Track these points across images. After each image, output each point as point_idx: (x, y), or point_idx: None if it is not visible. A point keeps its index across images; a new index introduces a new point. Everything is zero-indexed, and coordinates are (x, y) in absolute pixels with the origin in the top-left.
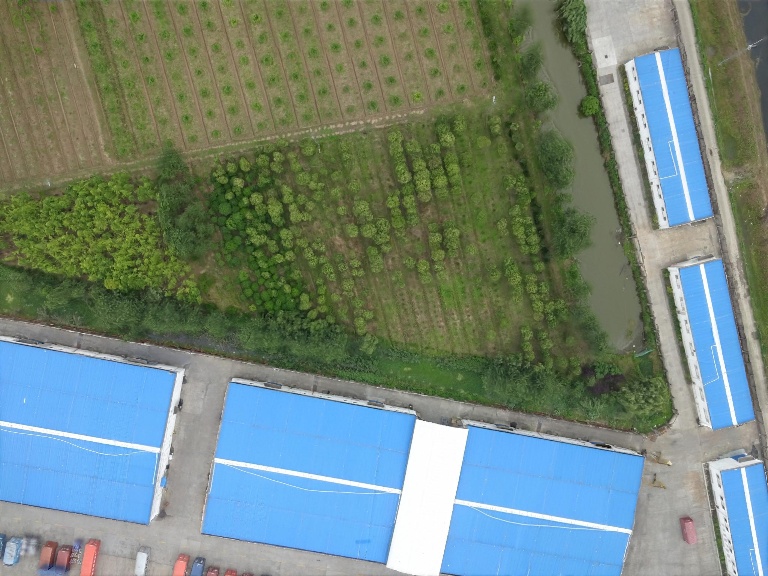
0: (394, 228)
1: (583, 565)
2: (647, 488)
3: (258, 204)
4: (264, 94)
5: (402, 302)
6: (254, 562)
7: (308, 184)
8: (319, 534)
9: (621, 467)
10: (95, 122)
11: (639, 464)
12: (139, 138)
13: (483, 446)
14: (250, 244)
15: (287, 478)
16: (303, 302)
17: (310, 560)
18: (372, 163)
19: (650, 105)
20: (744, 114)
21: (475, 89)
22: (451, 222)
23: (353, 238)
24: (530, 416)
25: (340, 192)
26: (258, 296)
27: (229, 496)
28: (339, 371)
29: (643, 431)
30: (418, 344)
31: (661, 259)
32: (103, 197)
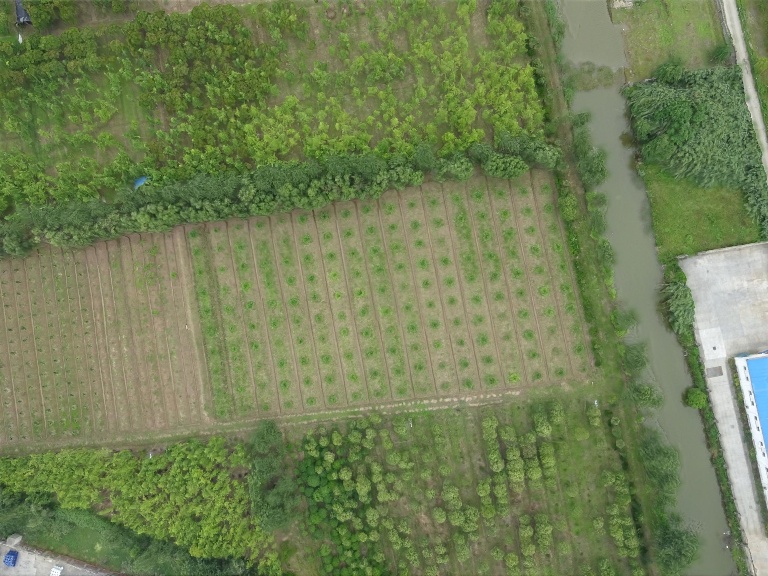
0: (483, 517)
1: None
2: None
3: (347, 480)
4: (361, 364)
5: None
6: None
7: (398, 463)
8: None
9: None
10: (198, 381)
11: None
12: (238, 400)
13: None
14: (335, 517)
15: None
16: None
17: None
18: (463, 441)
19: (764, 411)
20: None
21: (574, 373)
22: (544, 518)
23: None
24: None
25: (430, 475)
26: (338, 573)
27: None
28: None
29: None
30: None
31: None
32: (198, 462)
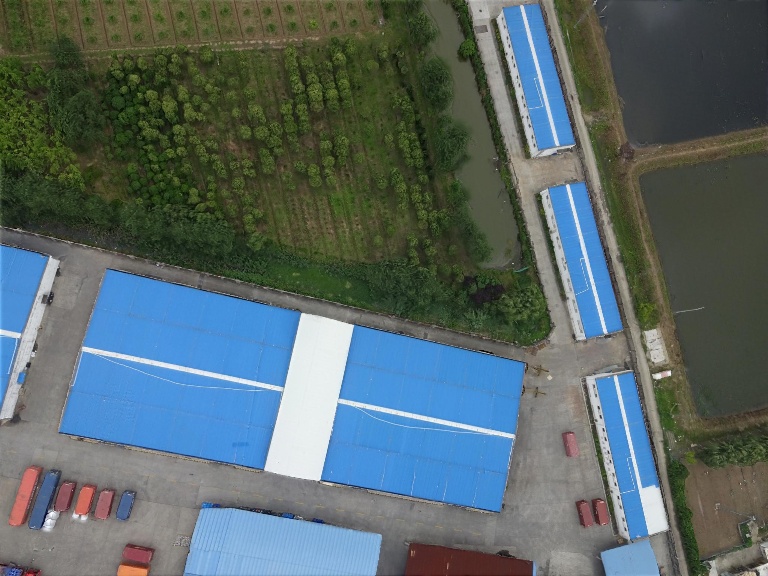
0: (286, 133)
1: (469, 473)
2: (530, 402)
3: (153, 100)
4: (167, 9)
5: (293, 207)
6: (118, 476)
7: (204, 87)
8: (193, 435)
9: (503, 372)
10: None
11: (520, 369)
12: (36, 34)
13: (369, 346)
14: (142, 139)
15: (161, 371)
16: (192, 195)
17: (182, 474)
18: (268, 78)
19: (517, 47)
20: (597, 68)
21: (366, 25)
22: (341, 130)
23: (247, 144)
24: (416, 326)
25: (235, 96)
26: (146, 189)
27: (95, 390)
28: (226, 271)
29: (524, 344)
30: (307, 249)
31: (534, 185)
32: None
